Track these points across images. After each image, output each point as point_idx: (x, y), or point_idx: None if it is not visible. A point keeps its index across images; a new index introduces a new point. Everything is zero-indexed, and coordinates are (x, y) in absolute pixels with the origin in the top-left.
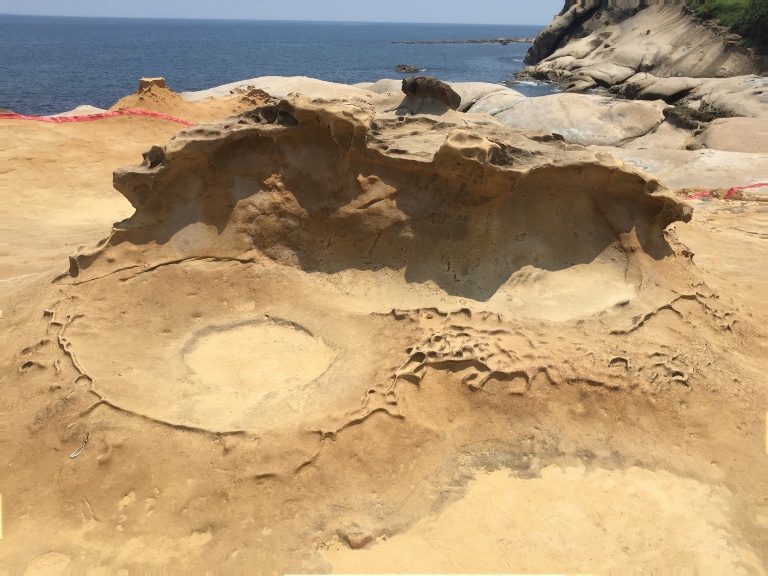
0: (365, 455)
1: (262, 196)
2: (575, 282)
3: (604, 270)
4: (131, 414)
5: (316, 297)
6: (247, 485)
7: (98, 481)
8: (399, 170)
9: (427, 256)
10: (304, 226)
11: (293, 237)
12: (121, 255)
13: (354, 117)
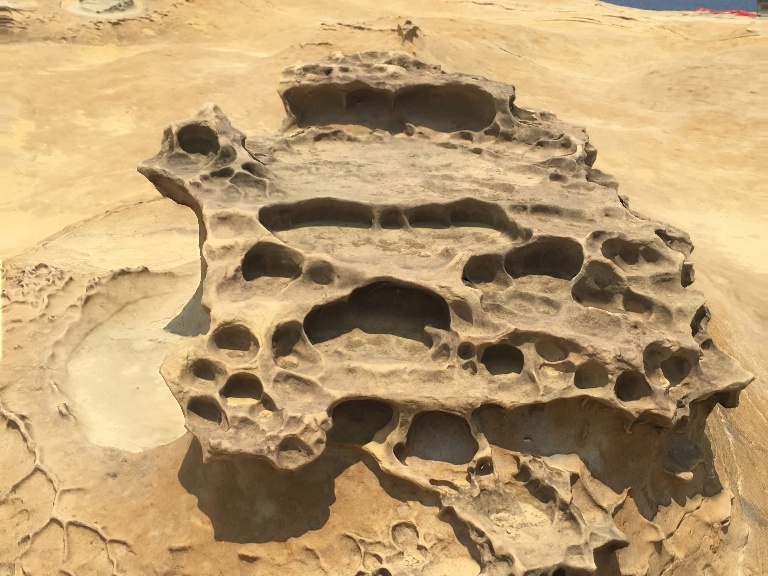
0: None
1: None
2: None
3: None
4: None
5: None
6: None
7: None
8: None
9: None
10: None
11: None
12: None
13: None
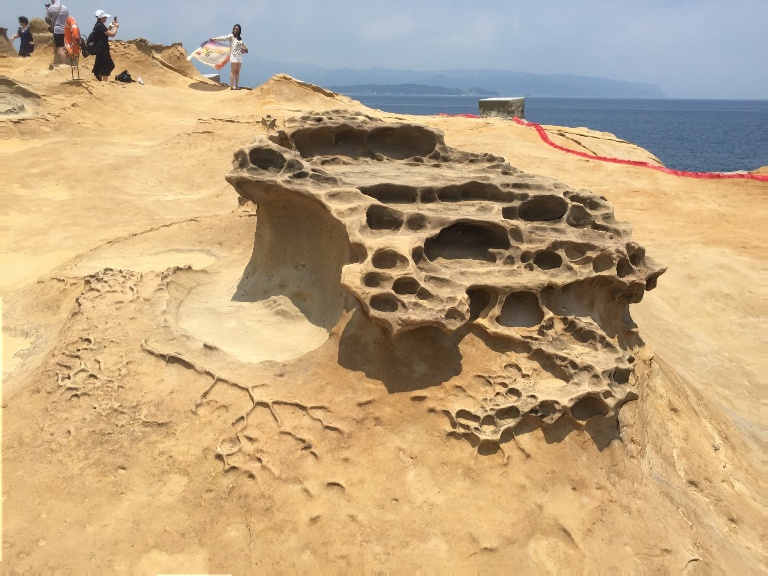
0: (41, 294)
1: None
2: (291, 336)
3: None
4: None
5: None
6: None
7: None
8: None
9: None
10: None
11: None
12: None
13: None
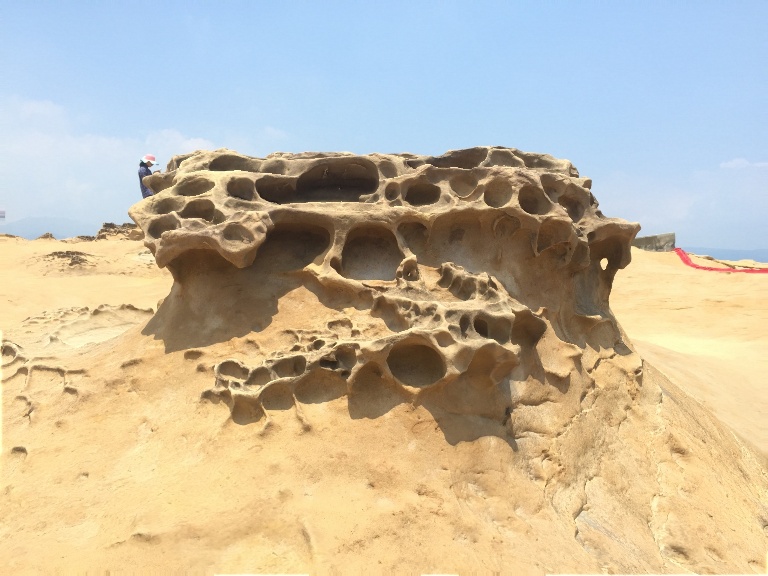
0: None
1: None
2: None
3: None
4: None
5: None
6: None
7: None
8: None
9: None
10: None
11: None
12: None
13: None
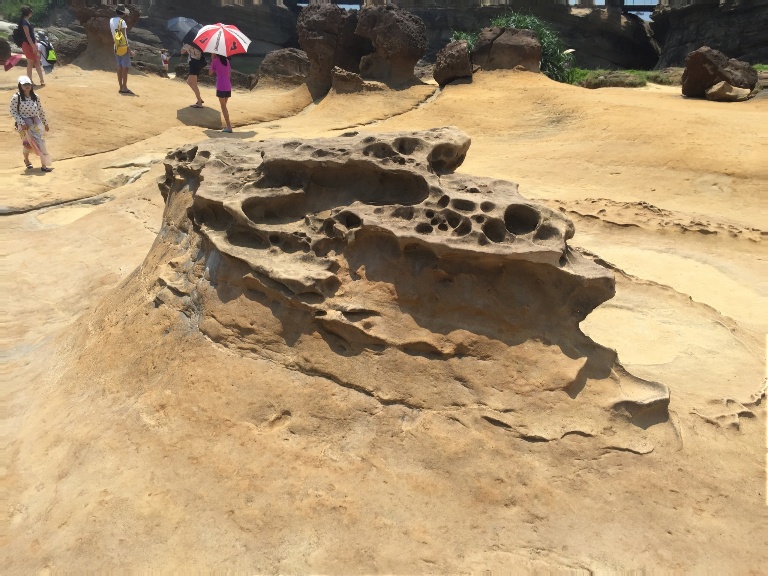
0: None
1: None
2: None
3: None
4: None
5: None
6: None
7: None
8: None
9: None
10: None
11: None
12: None
13: None
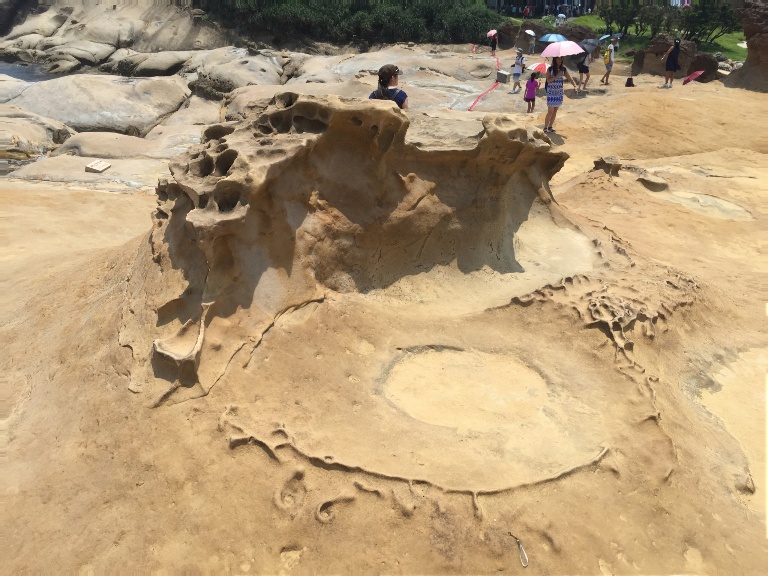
0: (678, 421)
1: (310, 220)
2: (536, 238)
3: (538, 223)
4: (511, 491)
5: (406, 315)
6: (664, 491)
7: (574, 570)
8: (429, 163)
9: (476, 243)
10: (358, 243)
11: (348, 258)
12: (222, 336)
13: (402, 113)
